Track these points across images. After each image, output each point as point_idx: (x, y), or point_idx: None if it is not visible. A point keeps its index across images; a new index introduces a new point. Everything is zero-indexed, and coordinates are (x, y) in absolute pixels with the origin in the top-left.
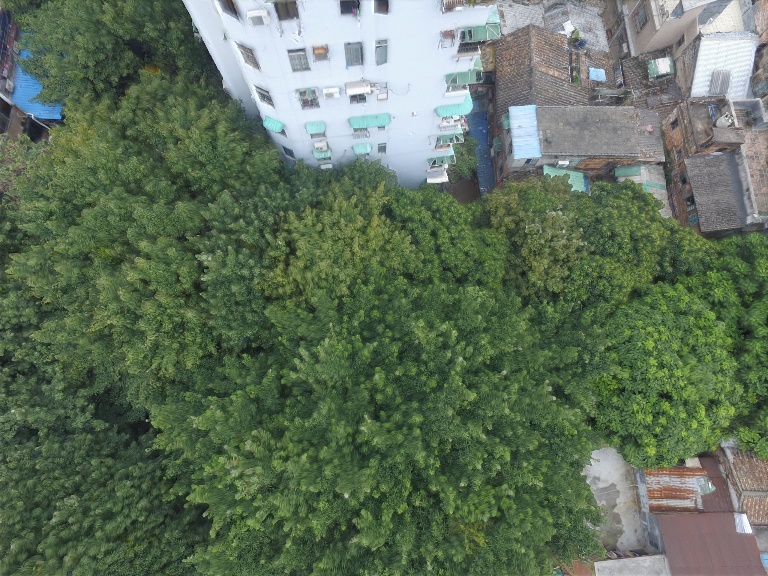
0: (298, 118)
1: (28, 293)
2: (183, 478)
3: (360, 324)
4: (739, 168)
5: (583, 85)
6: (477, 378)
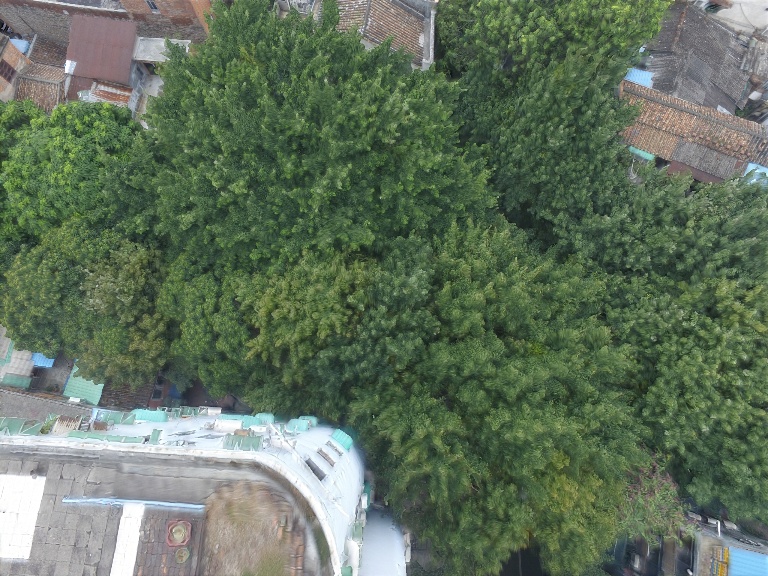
0: None
1: (615, 334)
2: (475, 159)
3: (302, 230)
4: None
5: None
6: (211, 157)
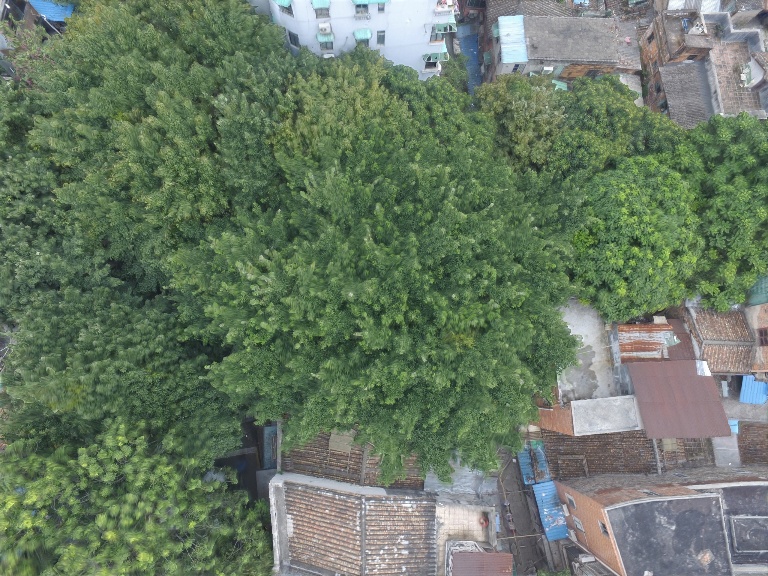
0: None
1: (48, 160)
2: (196, 323)
3: (361, 178)
4: (708, 74)
5: (568, 7)
6: (467, 214)
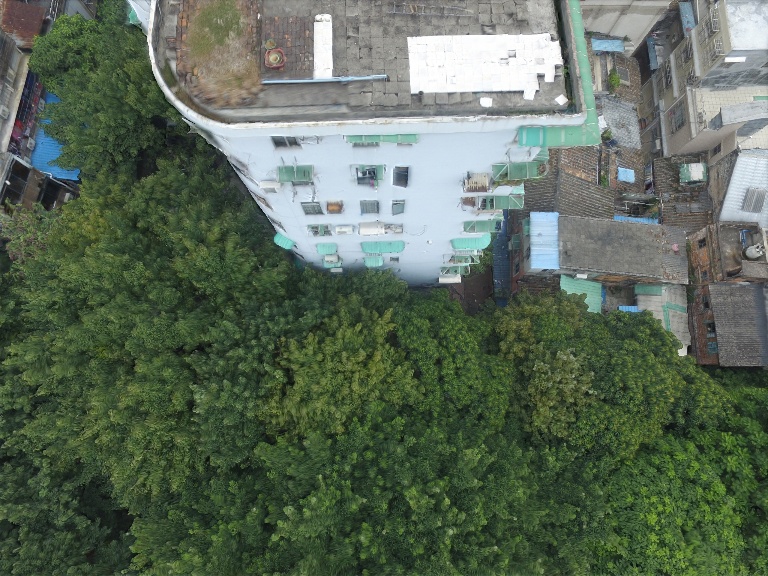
0: (309, 241)
1: None
2: None
3: None
4: (766, 302)
5: (610, 186)
6: (467, 546)
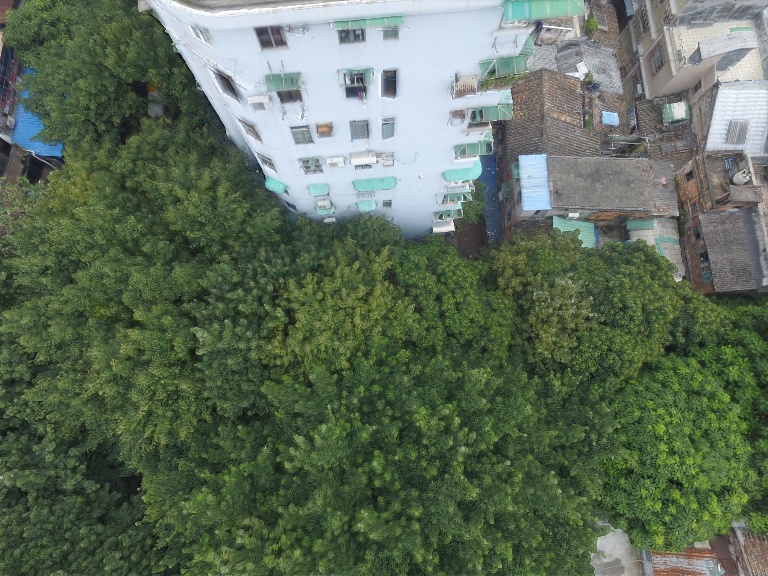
0: (301, 181)
1: (21, 348)
2: (174, 548)
3: (360, 397)
4: (756, 227)
5: (595, 130)
6: (480, 465)
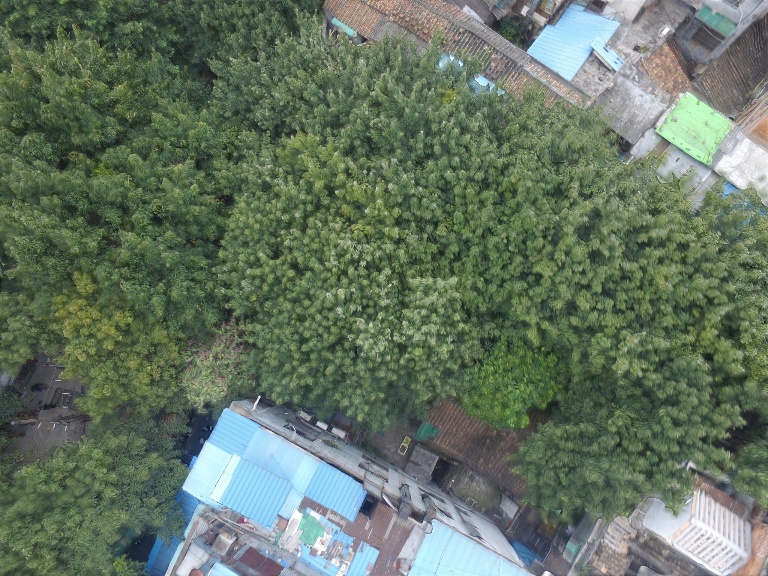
0: None
1: (216, 185)
2: None
3: None
4: None
5: None
6: None
